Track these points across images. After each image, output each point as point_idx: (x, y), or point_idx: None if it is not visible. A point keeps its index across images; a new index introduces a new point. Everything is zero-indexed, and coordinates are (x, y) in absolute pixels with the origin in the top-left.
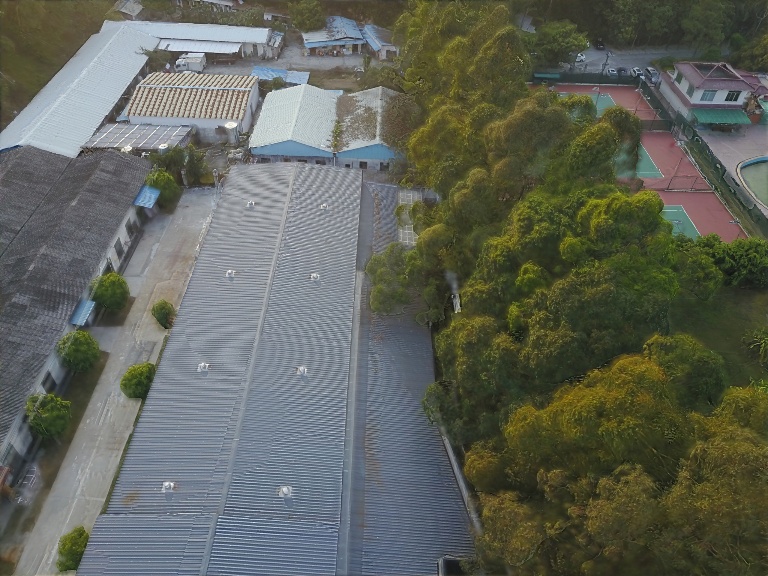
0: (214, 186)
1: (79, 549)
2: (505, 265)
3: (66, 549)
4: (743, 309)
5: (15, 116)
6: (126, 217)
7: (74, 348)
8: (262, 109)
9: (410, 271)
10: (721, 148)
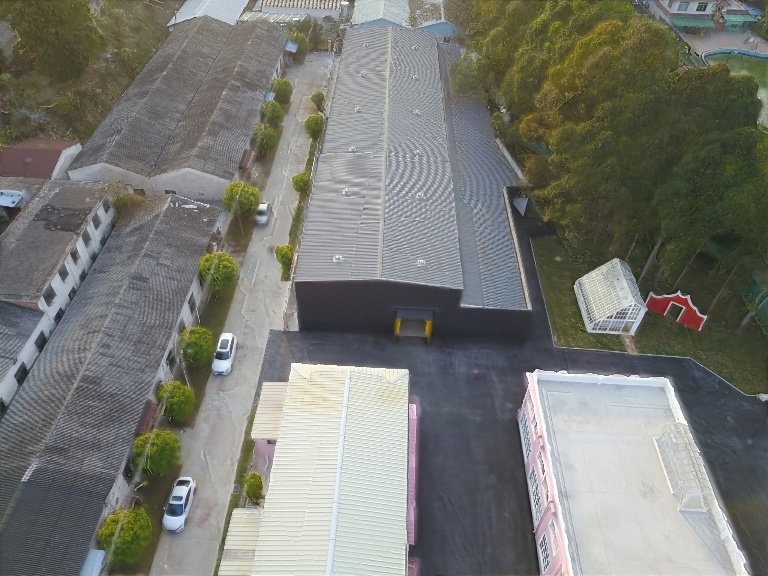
0: (327, 51)
1: (306, 179)
2: (542, 29)
3: (300, 177)
4: None
5: (177, 8)
6: (280, 56)
7: (272, 108)
8: (355, 5)
9: (478, 67)
10: (692, 44)
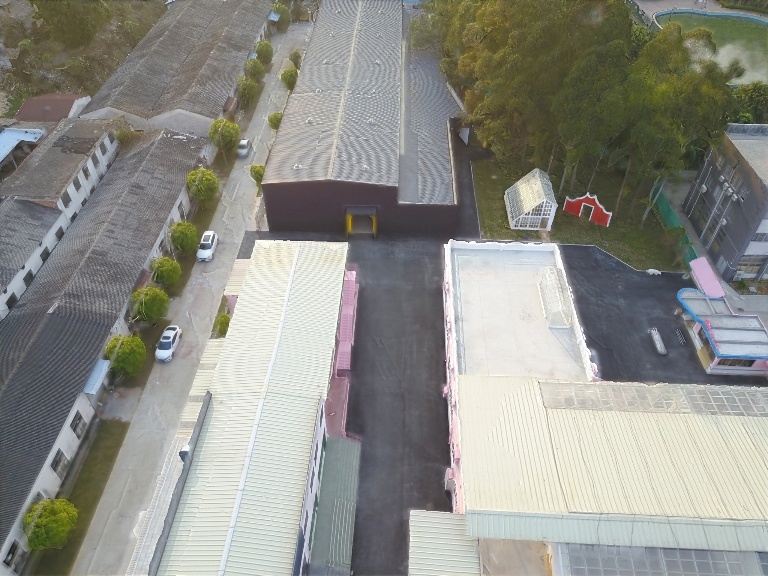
0: (308, 21)
1: (279, 117)
2: None
3: (274, 115)
4: None
5: None
6: (264, 24)
7: (254, 65)
8: None
9: (432, 23)
10: (646, 5)
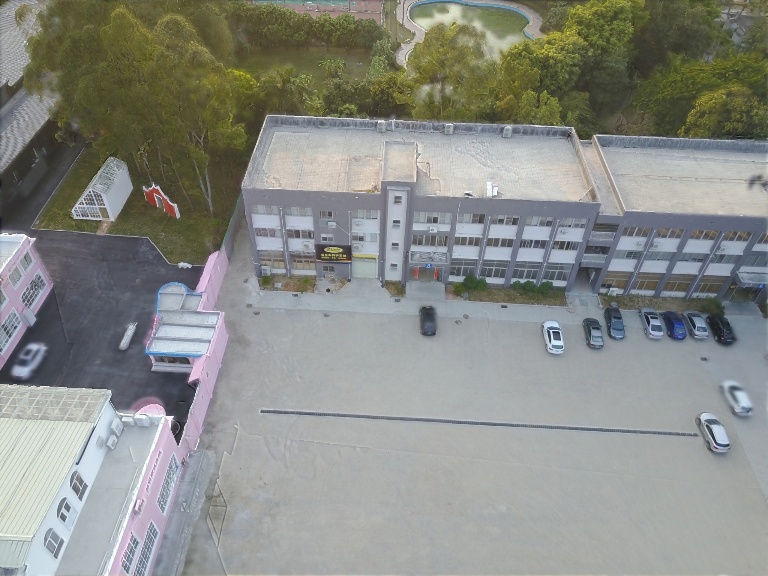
0: None
1: None
2: None
3: None
4: (345, 60)
5: None
6: None
7: None
8: None
9: None
10: None
